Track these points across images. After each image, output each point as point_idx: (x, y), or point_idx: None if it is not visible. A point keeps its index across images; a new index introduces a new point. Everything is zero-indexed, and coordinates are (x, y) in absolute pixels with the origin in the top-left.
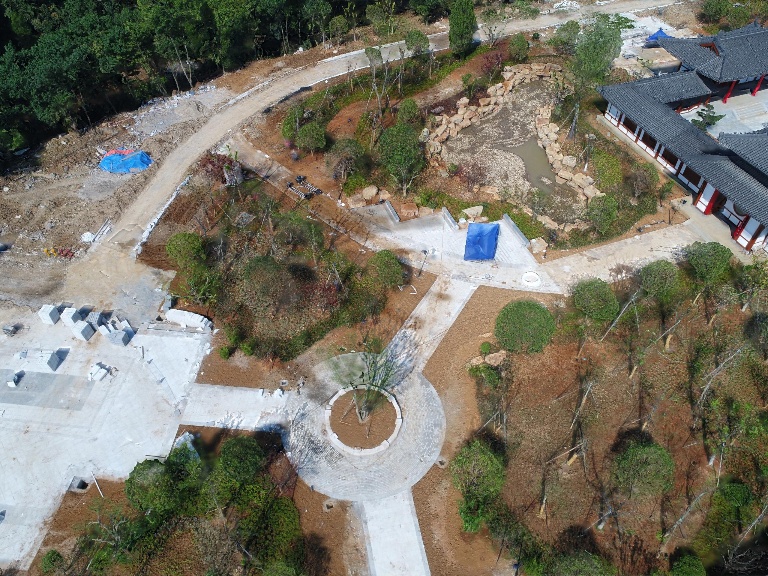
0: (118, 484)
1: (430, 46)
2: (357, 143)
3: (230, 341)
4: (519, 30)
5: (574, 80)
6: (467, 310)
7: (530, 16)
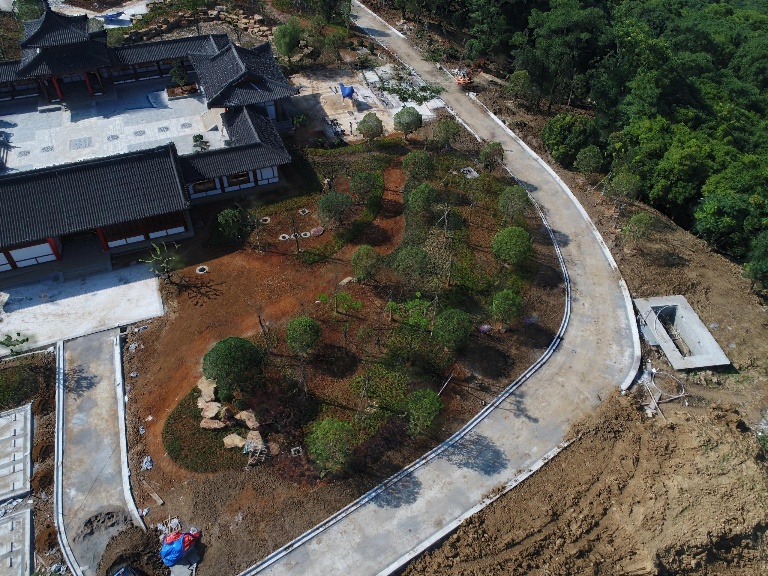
0: None
1: (362, 19)
2: None
3: None
4: (396, 52)
5: None
6: None
7: None
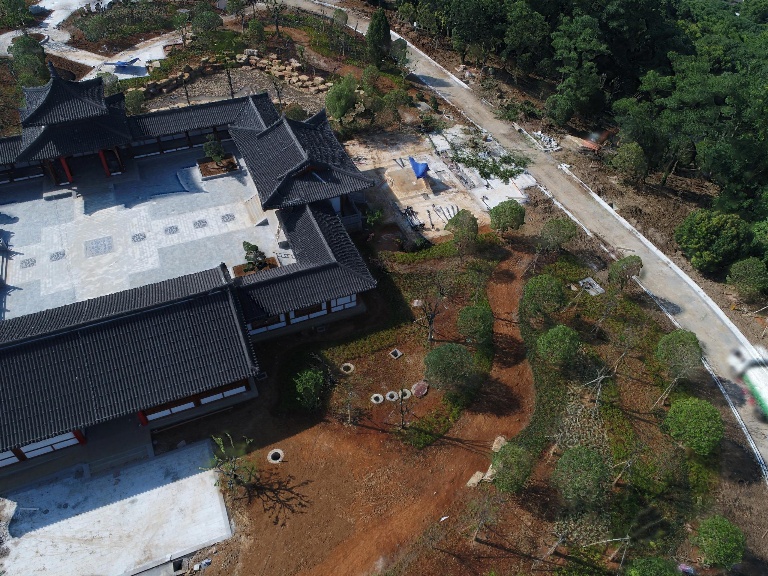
0: (36, 3)
1: None
2: (205, 8)
3: (86, 8)
4: (462, 107)
5: (339, 120)
6: (77, 63)
7: (501, 115)
